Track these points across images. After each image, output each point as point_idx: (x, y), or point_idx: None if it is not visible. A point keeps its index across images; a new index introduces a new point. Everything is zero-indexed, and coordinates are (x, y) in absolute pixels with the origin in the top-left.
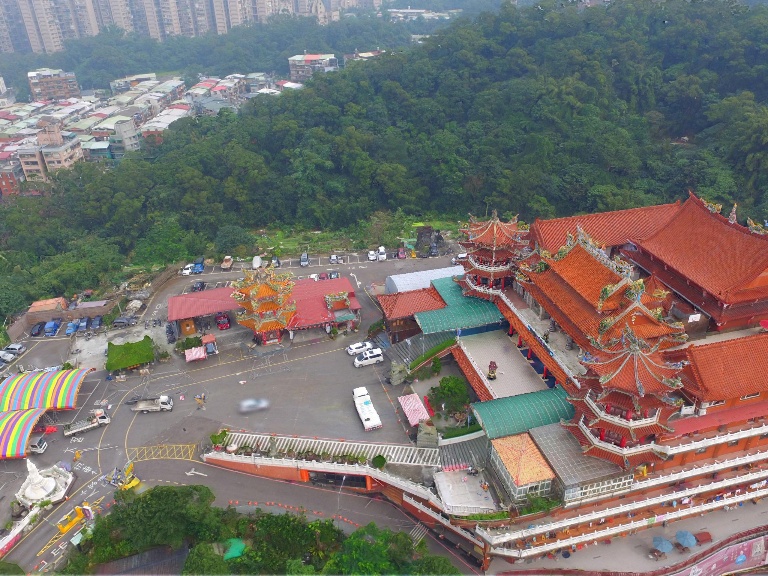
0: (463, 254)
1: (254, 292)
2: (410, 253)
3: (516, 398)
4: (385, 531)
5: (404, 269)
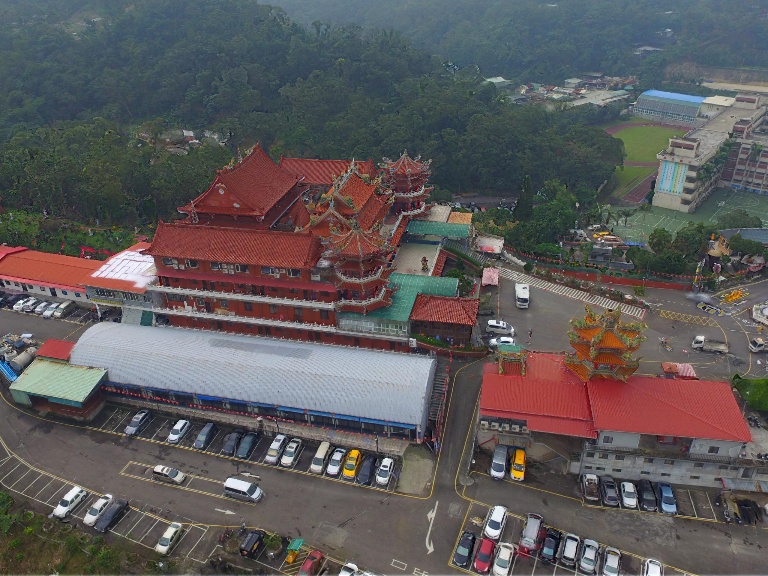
0: (241, 486)
1: (618, 313)
2: (292, 567)
3: (440, 229)
4: (538, 248)
5: (341, 520)
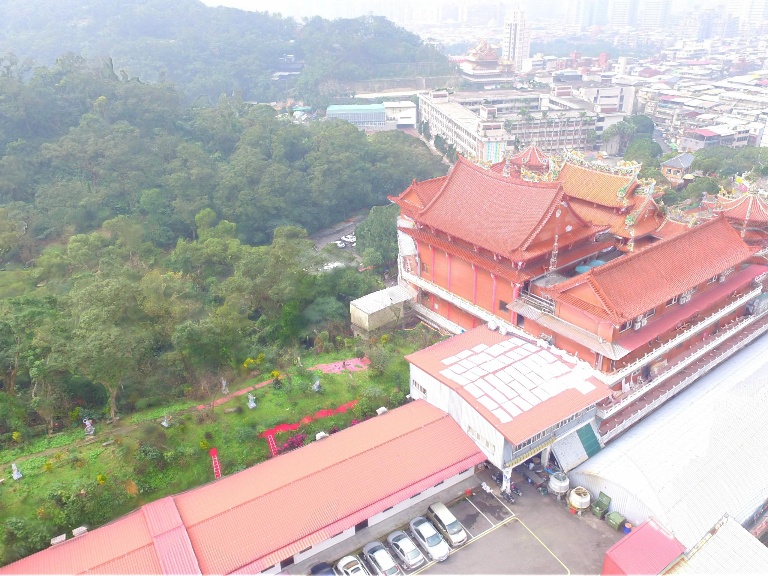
0: None
1: None
2: None
3: None
4: None
5: None
